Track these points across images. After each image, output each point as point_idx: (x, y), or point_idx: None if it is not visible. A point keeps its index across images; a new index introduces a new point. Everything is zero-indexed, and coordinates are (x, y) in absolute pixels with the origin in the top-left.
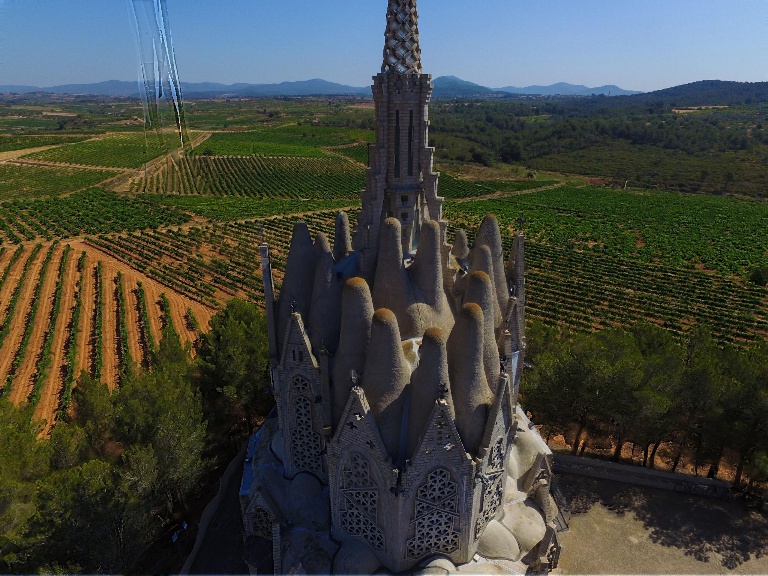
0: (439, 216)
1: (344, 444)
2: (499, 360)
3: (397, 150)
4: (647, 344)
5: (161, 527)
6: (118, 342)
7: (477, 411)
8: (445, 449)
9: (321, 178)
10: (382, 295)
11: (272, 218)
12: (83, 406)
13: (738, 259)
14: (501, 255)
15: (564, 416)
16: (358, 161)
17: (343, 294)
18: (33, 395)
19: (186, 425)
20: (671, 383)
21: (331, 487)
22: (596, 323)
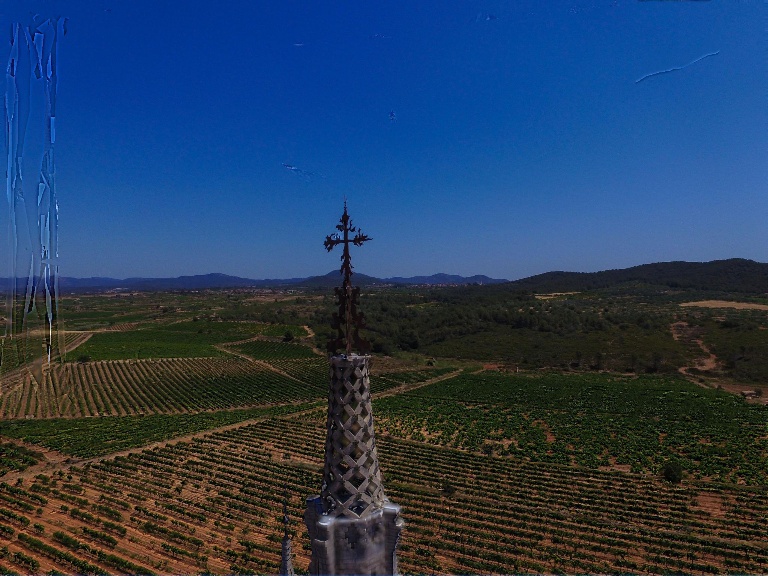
0: None
1: None
2: None
3: None
4: None
5: None
6: None
7: None
8: None
9: (216, 382)
10: None
11: (152, 446)
12: None
13: (642, 449)
14: None
15: None
16: (257, 358)
17: None
18: None
19: None
20: None
21: None
22: (547, 571)
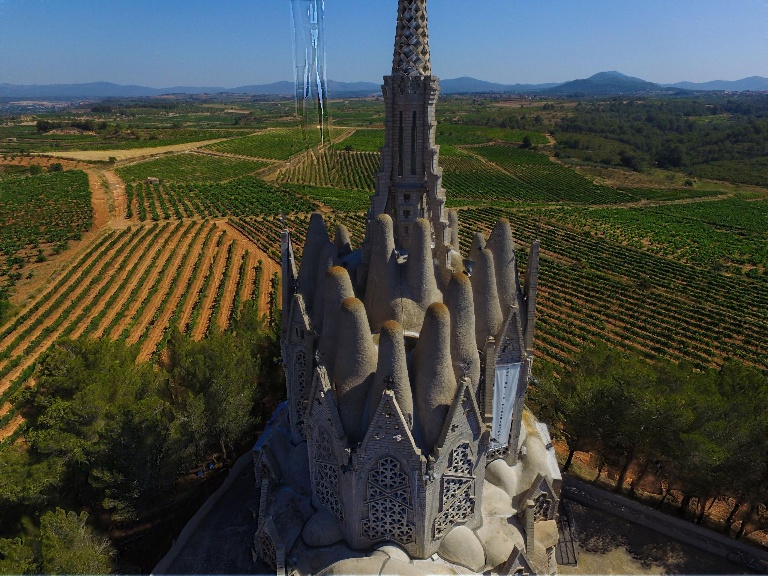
0: (440, 216)
1: (315, 418)
2: (479, 366)
3: (401, 149)
4: (731, 385)
5: (215, 468)
6: (232, 310)
7: (436, 410)
8: (395, 439)
9: (449, 176)
10: (372, 287)
11: None
12: (173, 355)
13: None
14: (512, 261)
15: (607, 447)
16: (490, 161)
17: (325, 280)
18: (160, 343)
19: (238, 384)
20: (736, 433)
21: (309, 456)
22: (720, 358)
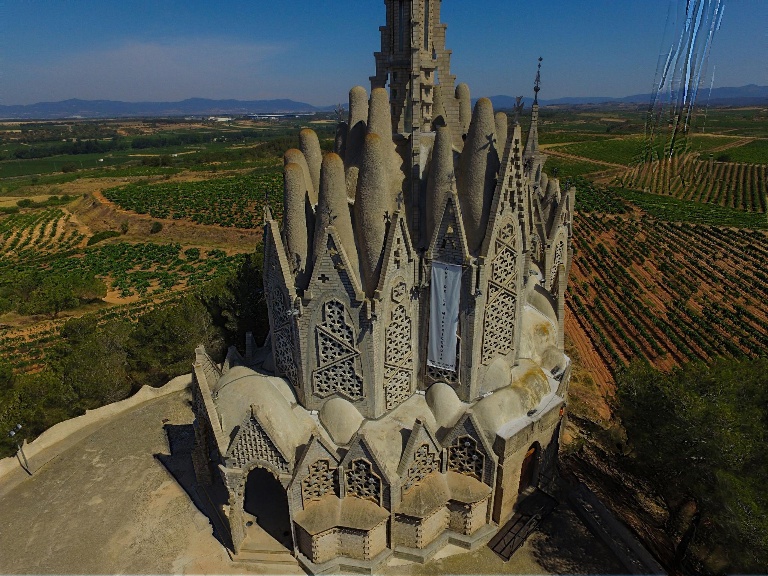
0: (413, 92)
1: None
2: (382, 238)
3: None
4: None
5: None
6: None
7: None
8: None
9: None
10: None
11: None
12: None
13: None
14: (483, 149)
15: None
16: None
17: None
18: None
19: None
20: None
21: None
22: None
